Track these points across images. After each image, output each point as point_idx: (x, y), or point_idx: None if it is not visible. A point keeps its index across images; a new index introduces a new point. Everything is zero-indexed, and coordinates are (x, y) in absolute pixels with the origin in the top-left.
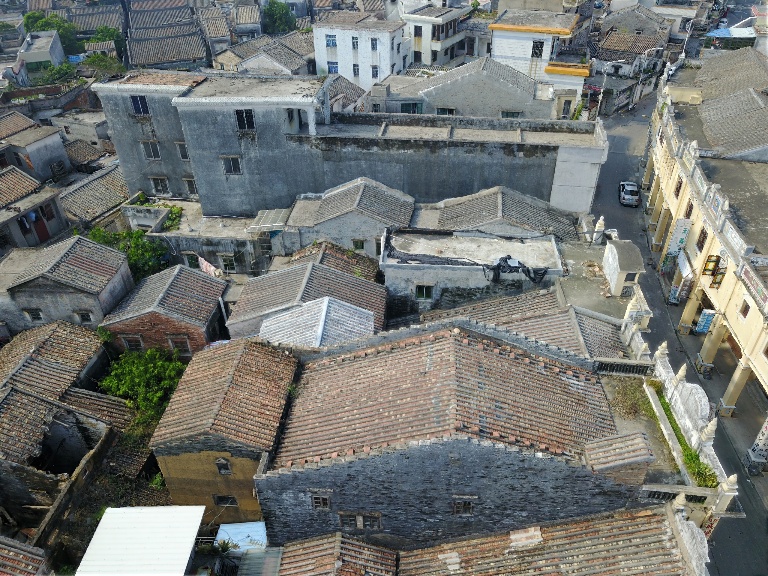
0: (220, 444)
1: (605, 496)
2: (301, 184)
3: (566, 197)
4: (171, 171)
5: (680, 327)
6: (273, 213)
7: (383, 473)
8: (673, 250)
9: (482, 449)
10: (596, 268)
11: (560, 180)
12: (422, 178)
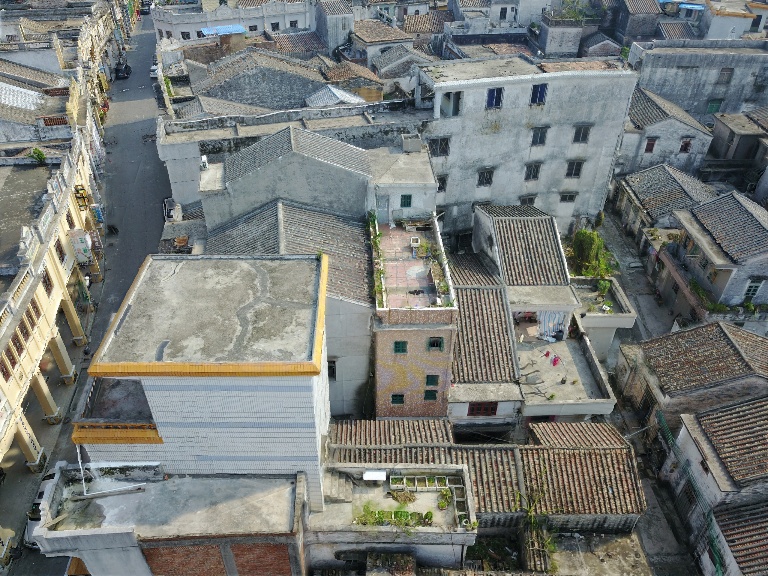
0: None
1: None
2: None
3: None
4: None
5: None
6: None
7: None
8: (88, 259)
9: None
10: None
11: None
12: None
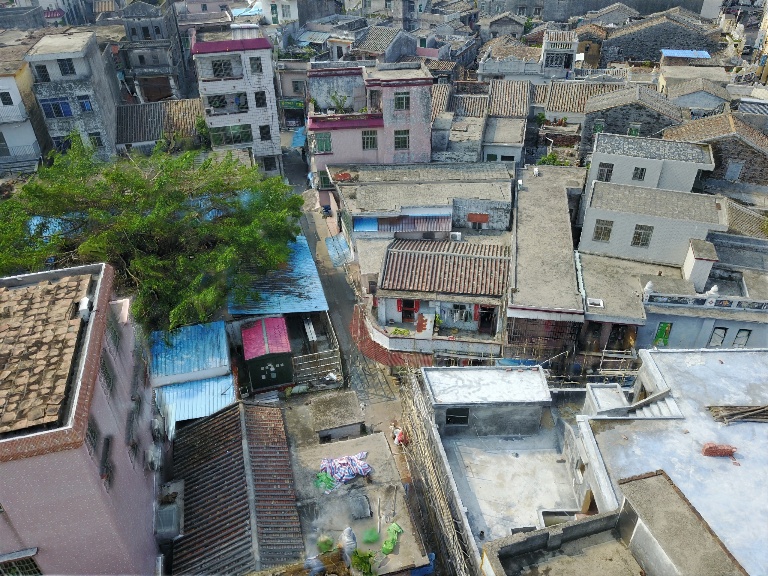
0: (590, 37)
1: (708, 47)
2: (590, 6)
3: (708, 12)
4: (529, 4)
5: None
6: (577, 16)
7: (643, 37)
8: (757, 46)
9: (674, 26)
10: (716, 27)
11: (706, 3)
12: (645, 3)
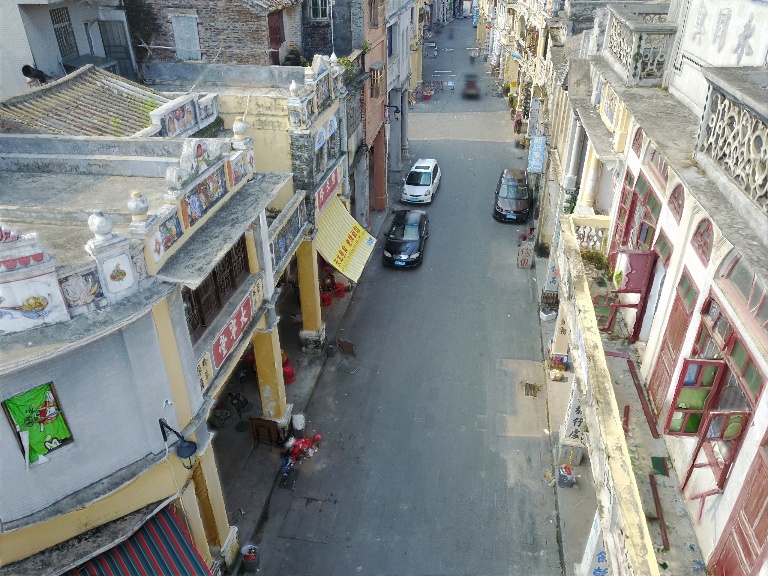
0: None
1: None
2: None
3: None
4: None
5: (477, 41)
6: None
7: None
8: None
9: None
10: None
11: None
12: None
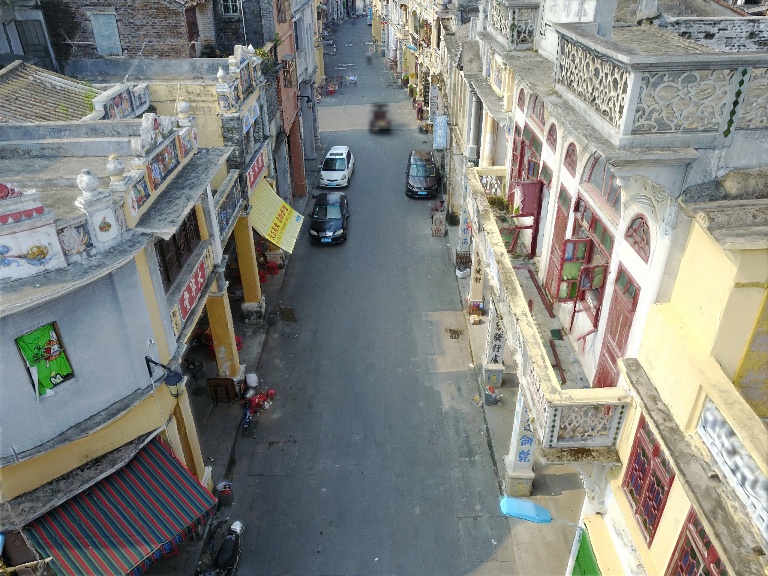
0: None
1: None
2: None
3: None
4: None
5: (373, 38)
6: None
7: None
8: None
9: None
10: None
11: None
12: None
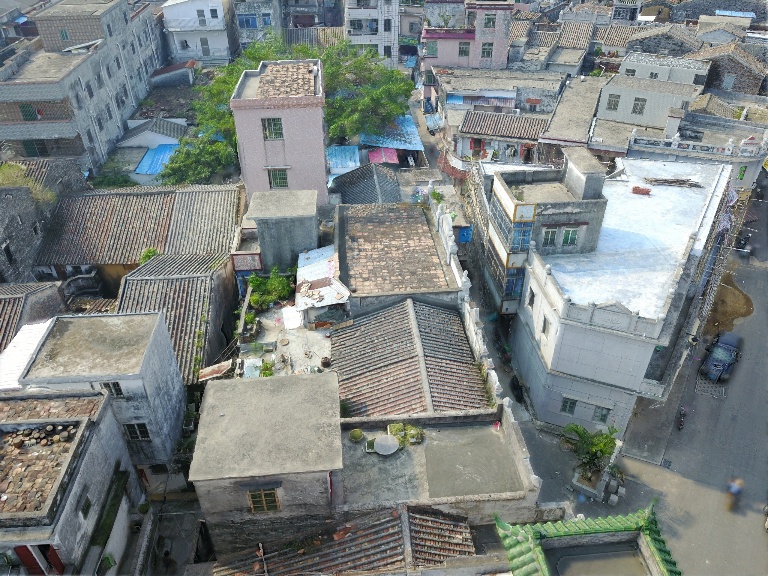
0: (663, 3)
1: (765, 14)
2: None
3: None
4: None
5: None
6: None
7: (708, 3)
8: None
9: None
10: None
11: None
12: None
